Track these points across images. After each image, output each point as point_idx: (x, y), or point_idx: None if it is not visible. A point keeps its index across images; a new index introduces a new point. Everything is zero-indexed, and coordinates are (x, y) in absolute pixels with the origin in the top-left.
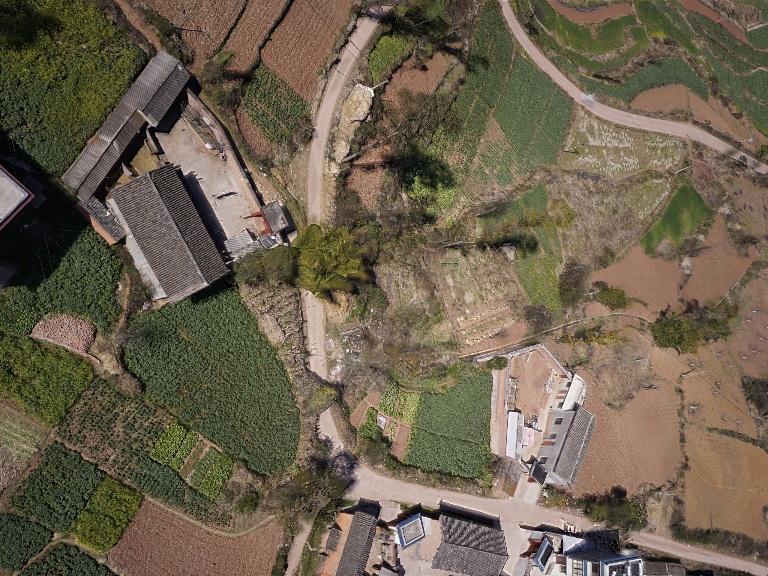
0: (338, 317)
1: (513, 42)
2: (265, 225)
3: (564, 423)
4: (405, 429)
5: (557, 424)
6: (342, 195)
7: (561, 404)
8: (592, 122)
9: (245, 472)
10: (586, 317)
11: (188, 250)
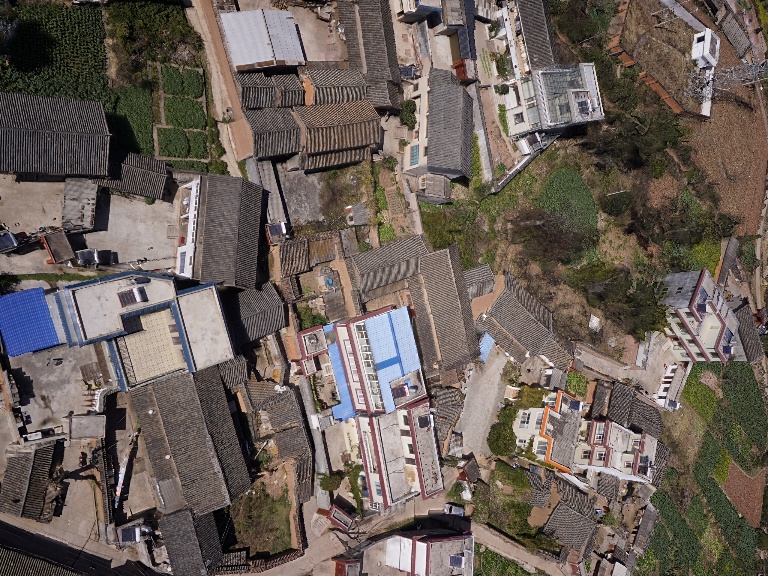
0: None
1: None
2: None
3: None
4: None
5: None
6: (766, 296)
7: None
8: None
9: None
10: None
11: (759, 340)
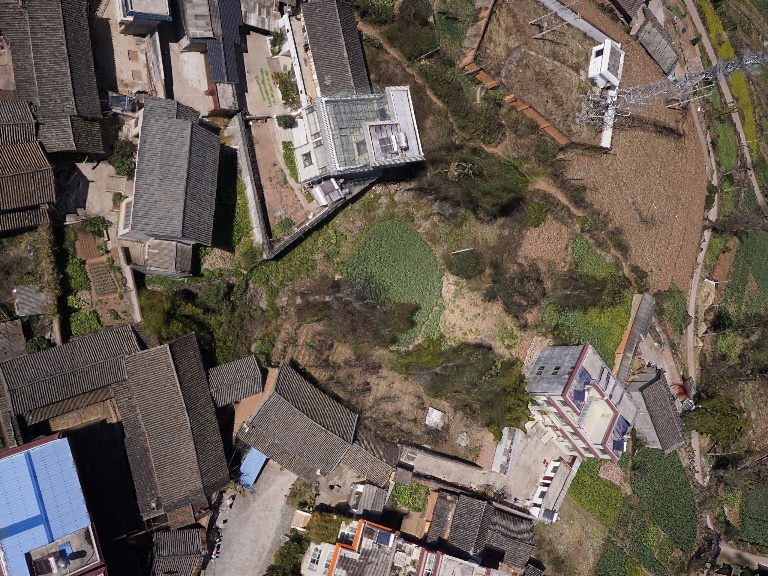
0: (705, 443)
1: (760, 212)
2: (679, 390)
3: None
4: (736, 515)
5: None
6: None
7: None
8: None
9: None
10: None
11: (676, 423)
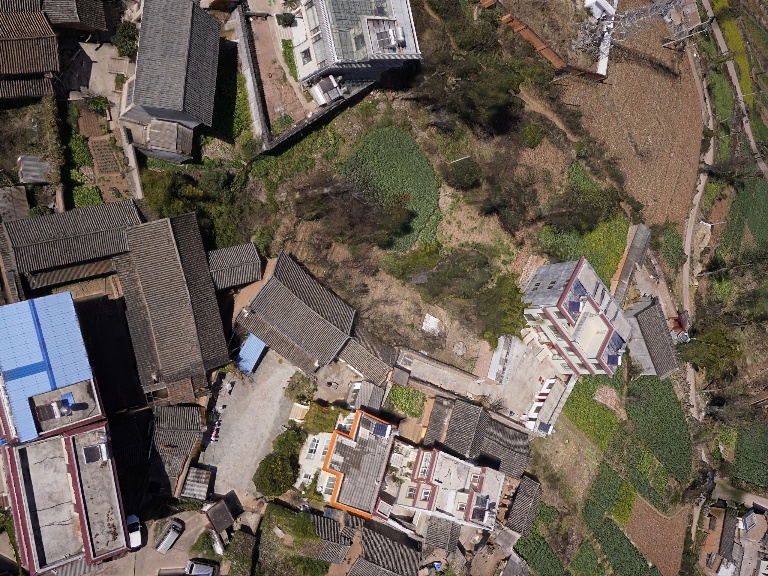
0: (701, 380)
1: (757, 167)
2: (675, 324)
3: None
4: (731, 454)
5: None
6: (697, 298)
7: None
8: None
9: (674, 480)
10: None
11: (671, 349)
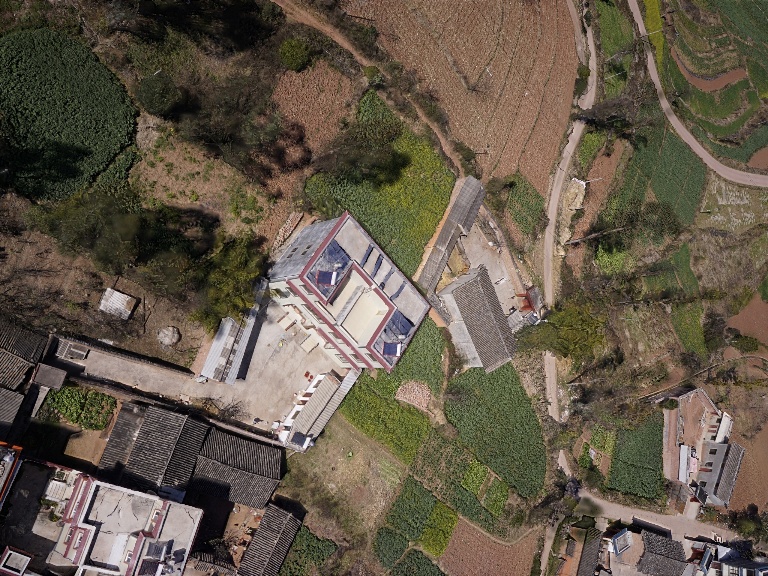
0: (565, 371)
1: (665, 120)
2: (524, 303)
3: (719, 454)
4: (607, 459)
5: (712, 454)
6: (564, 271)
7: (714, 437)
8: (721, 184)
9: (517, 496)
10: (724, 360)
11: (500, 334)
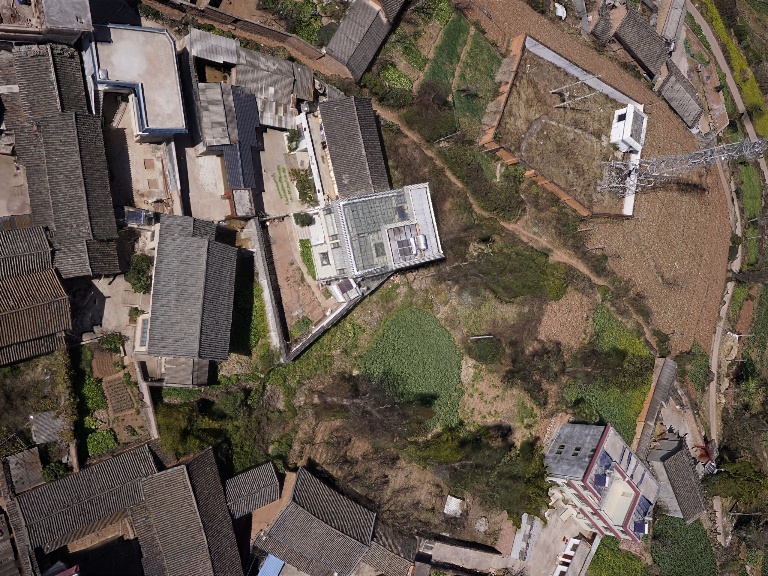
0: (727, 502)
1: None
2: (701, 452)
3: None
4: (758, 572)
5: None
6: (724, 414)
7: None
8: None
9: None
10: None
11: (698, 493)
